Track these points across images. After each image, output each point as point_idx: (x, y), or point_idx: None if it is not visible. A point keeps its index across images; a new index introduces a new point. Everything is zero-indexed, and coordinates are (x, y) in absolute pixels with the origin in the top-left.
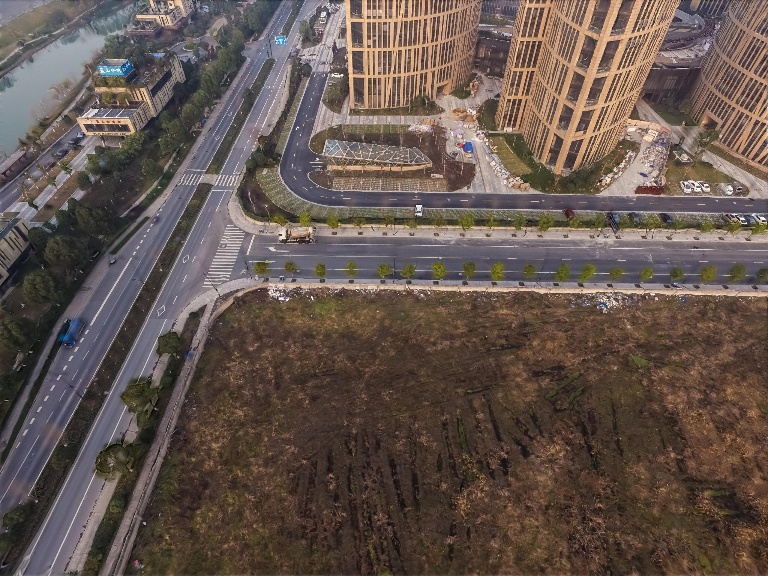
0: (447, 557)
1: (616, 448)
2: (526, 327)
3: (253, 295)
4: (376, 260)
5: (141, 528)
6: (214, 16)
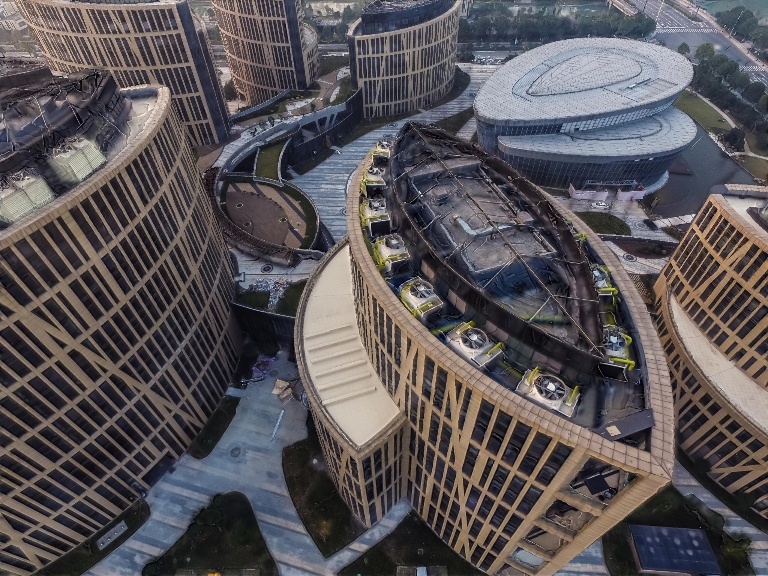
0: None
1: None
2: None
3: None
4: None
5: (13, 61)
6: None
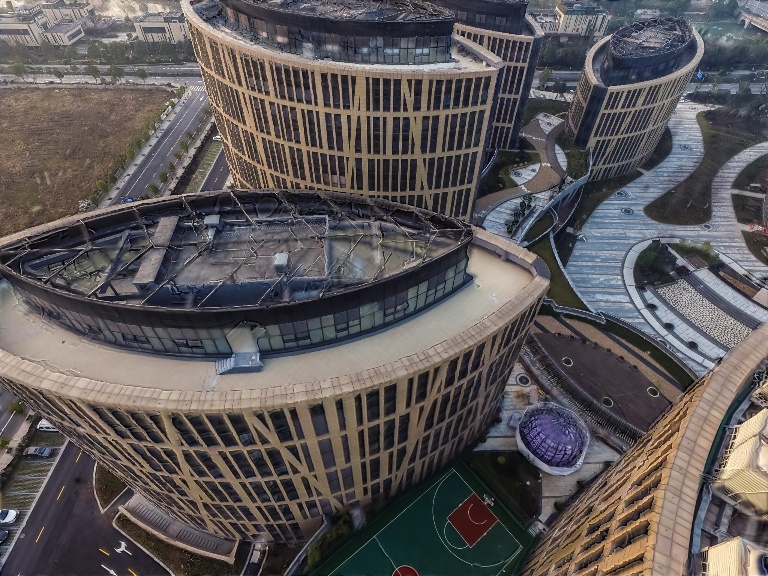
0: (5, 139)
1: (0, 187)
2: (93, 171)
3: (173, 95)
4: (183, 128)
5: None
6: (588, 47)
